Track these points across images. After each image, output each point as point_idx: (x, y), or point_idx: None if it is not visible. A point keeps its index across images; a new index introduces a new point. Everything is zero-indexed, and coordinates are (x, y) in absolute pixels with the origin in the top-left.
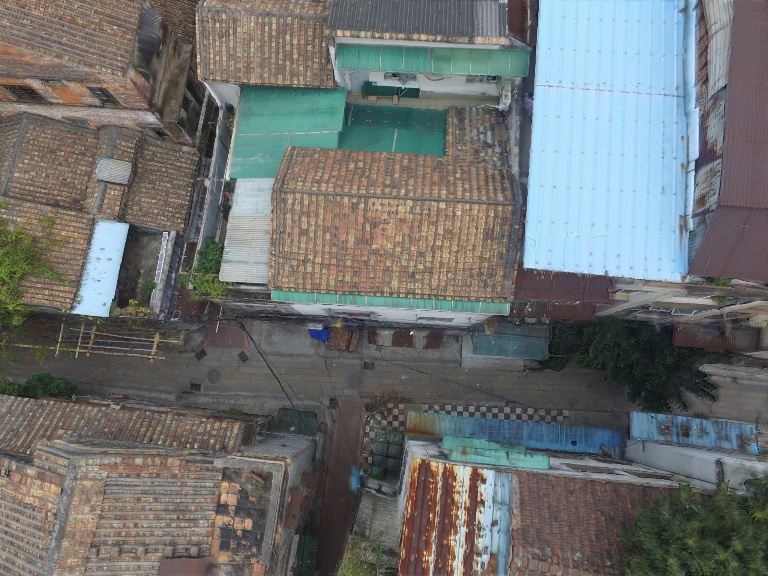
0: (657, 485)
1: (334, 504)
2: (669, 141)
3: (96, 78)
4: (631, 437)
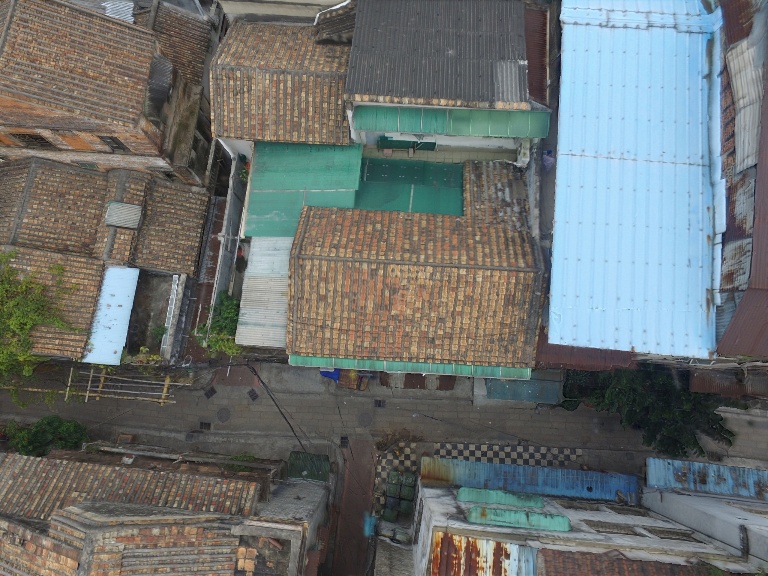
0: (681, 552)
1: (346, 546)
2: (695, 212)
3: (107, 129)
4: (648, 484)
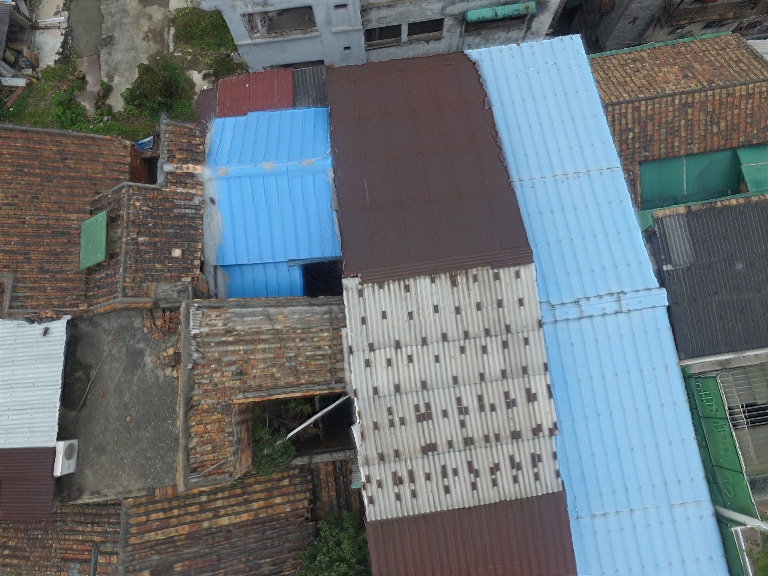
0: (405, 2)
1: None
2: None
3: None
4: None
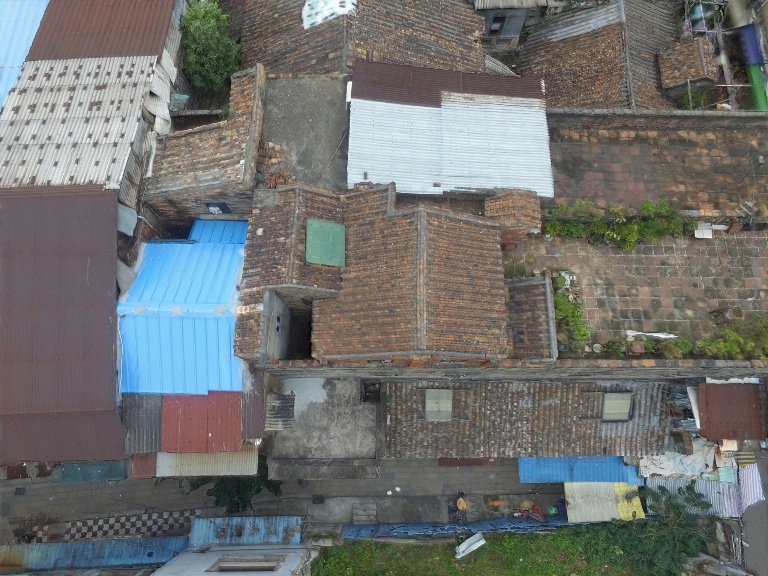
0: None
1: None
2: None
3: None
4: (188, 544)
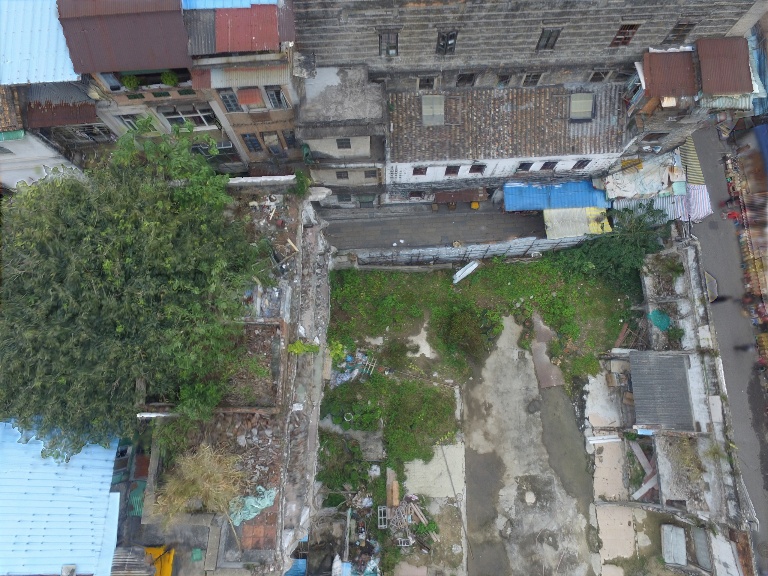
0: None
1: None
2: None
3: None
4: None
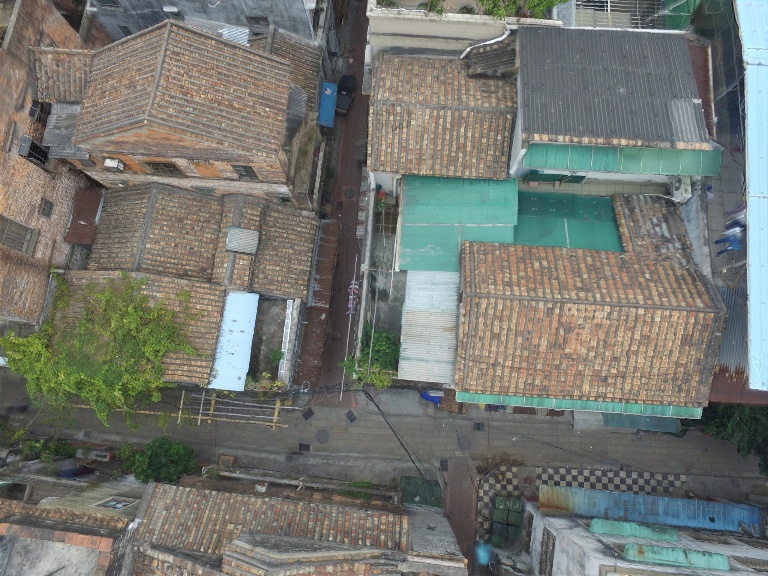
0: None
1: None
2: None
3: (246, 159)
4: None
